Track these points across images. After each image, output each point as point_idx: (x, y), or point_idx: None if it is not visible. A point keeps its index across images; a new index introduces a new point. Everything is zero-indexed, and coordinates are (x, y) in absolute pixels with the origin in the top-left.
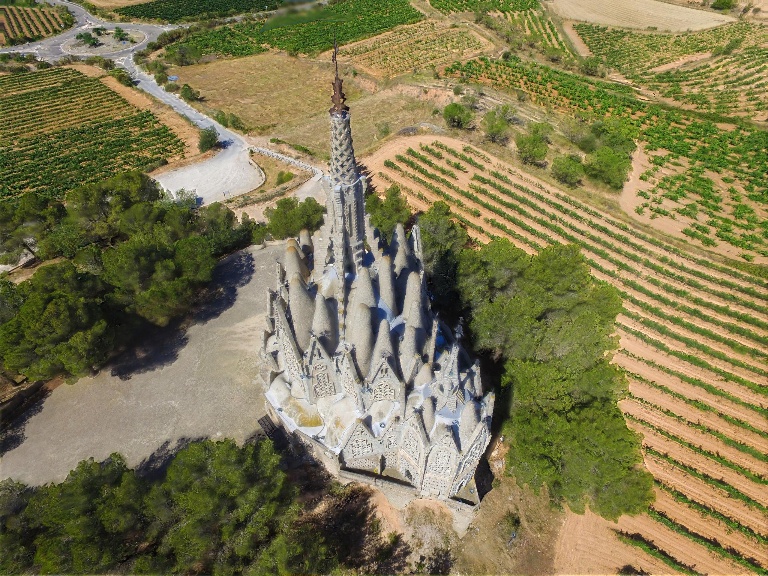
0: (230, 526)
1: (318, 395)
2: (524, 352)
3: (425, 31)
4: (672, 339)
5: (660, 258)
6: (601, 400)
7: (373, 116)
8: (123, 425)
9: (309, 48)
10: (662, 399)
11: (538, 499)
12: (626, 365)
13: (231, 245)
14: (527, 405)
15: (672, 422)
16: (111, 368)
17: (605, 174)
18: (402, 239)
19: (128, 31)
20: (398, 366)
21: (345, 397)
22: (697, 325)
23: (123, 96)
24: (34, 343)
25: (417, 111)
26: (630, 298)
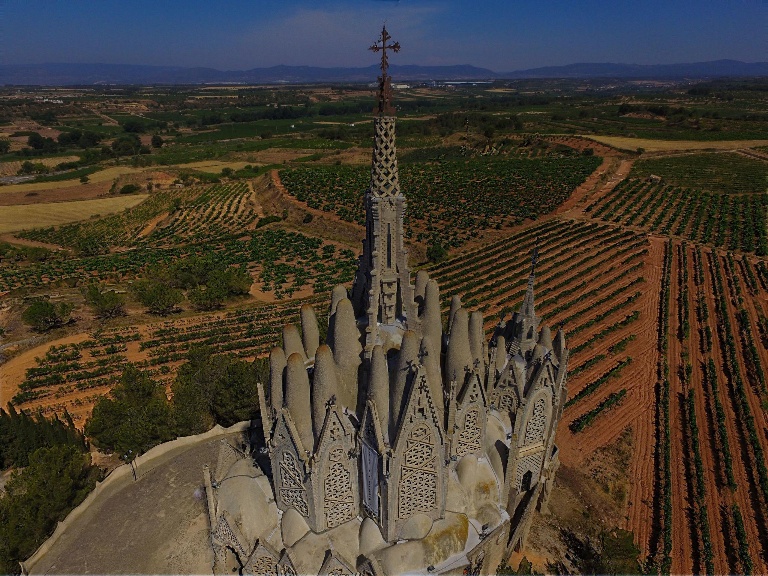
0: None
1: None
2: None
3: None
4: None
5: None
6: None
7: None
8: None
9: None
10: None
11: None
12: None
13: None
14: None
15: None
16: None
17: (234, 288)
18: None
19: None
20: None
21: (458, 465)
22: None
23: None
24: None
25: None
26: None
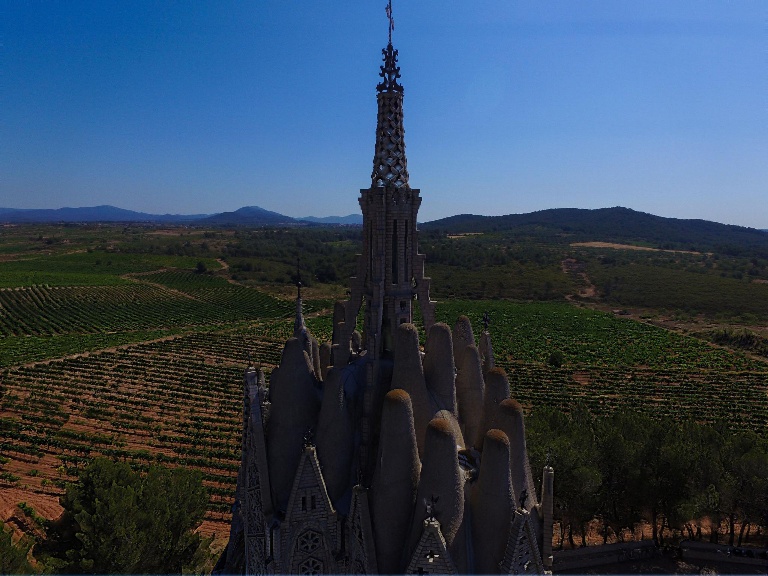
0: None
1: None
2: None
3: None
4: None
5: None
6: None
7: None
8: None
9: None
10: None
11: None
12: None
13: None
14: None
15: None
16: None
17: None
18: None
19: None
20: None
21: None
22: None
23: None
24: None
25: None
26: None
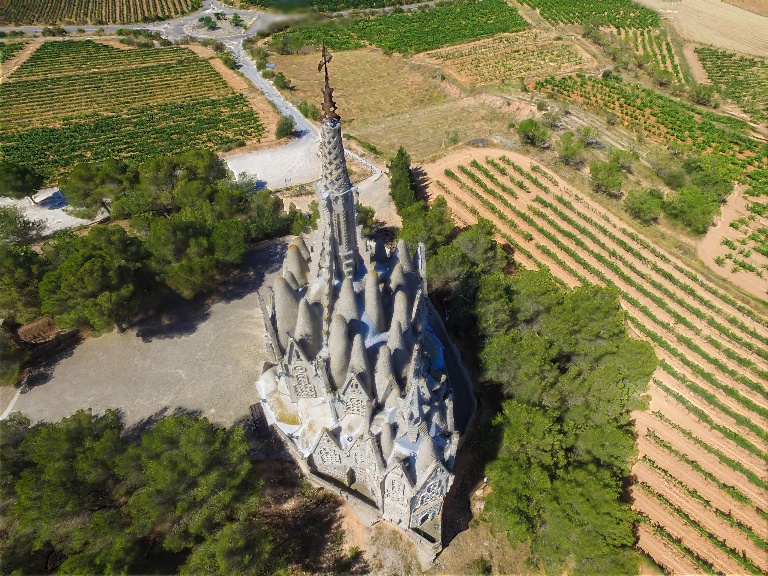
0: (185, 503)
1: (299, 395)
2: (529, 394)
3: (526, 41)
4: (721, 412)
5: (729, 318)
6: (604, 463)
7: (449, 123)
8: (133, 384)
9: (405, 48)
10: (691, 476)
11: (517, 552)
12: (657, 430)
13: (272, 232)
14: (515, 451)
15: (696, 505)
16: (138, 329)
17: (686, 215)
18: (403, 255)
19: (244, 18)
20: (373, 383)
21: (324, 402)
22: (756, 402)
23: (225, 78)
24: (68, 295)
25: (496, 122)
26: (681, 357)
